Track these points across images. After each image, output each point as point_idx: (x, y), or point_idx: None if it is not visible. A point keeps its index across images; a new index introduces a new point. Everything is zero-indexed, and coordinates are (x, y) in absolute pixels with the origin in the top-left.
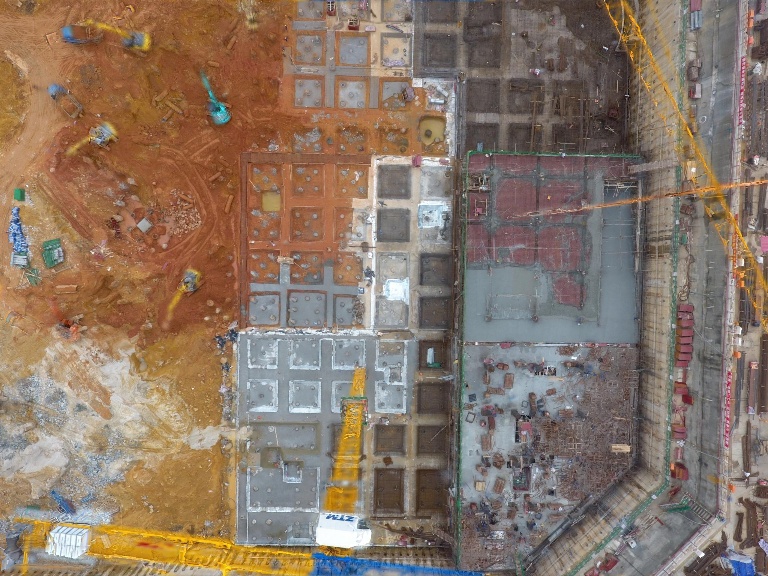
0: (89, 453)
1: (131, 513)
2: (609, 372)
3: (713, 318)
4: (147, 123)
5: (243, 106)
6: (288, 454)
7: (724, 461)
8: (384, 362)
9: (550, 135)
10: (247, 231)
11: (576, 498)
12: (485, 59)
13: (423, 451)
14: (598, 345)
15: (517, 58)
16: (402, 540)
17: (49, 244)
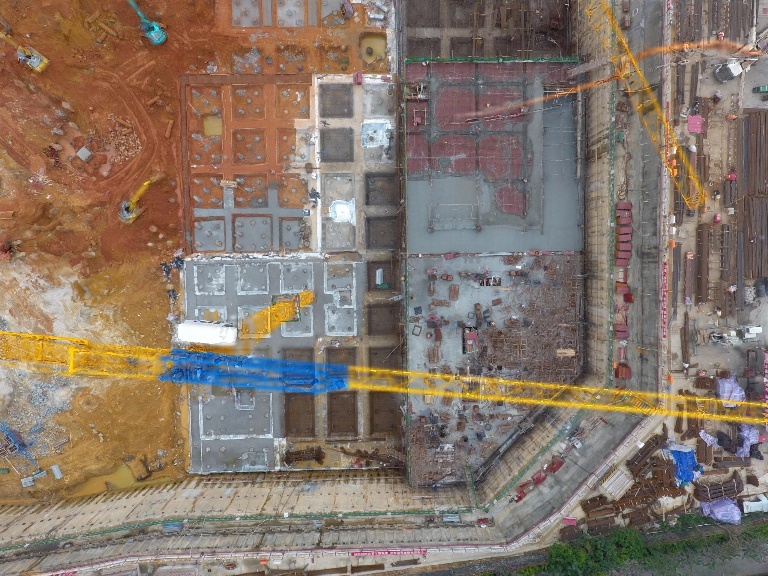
0: (34, 381)
1: (81, 443)
2: (554, 280)
3: (649, 211)
4: (81, 46)
5: (179, 27)
6: (239, 380)
7: (662, 352)
8: (333, 285)
9: (492, 49)
10: (188, 155)
11: (525, 408)
12: None
13: (376, 373)
14: (542, 253)
15: None
16: (357, 463)
17: None
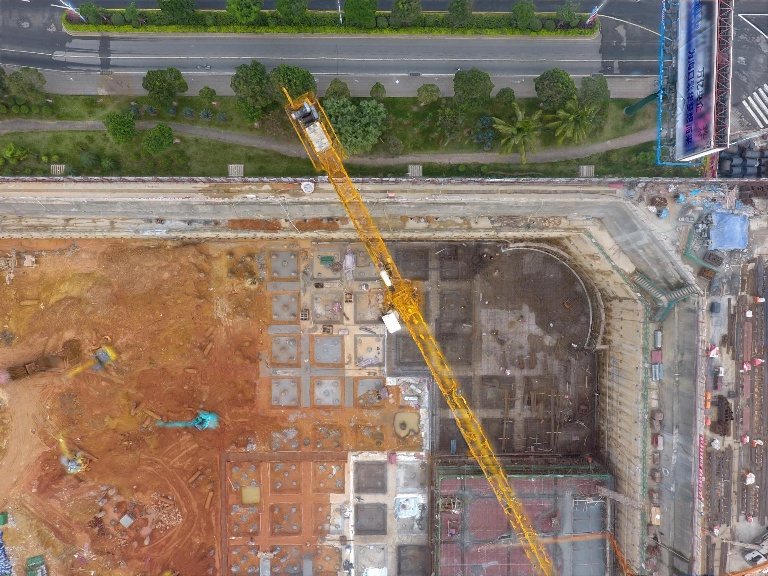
0: None
1: None
2: None
3: None
4: (127, 430)
5: (221, 410)
6: None
7: None
8: None
9: (522, 428)
10: (227, 527)
11: None
12: (457, 355)
13: None
14: None
15: (488, 356)
16: None
17: (32, 561)
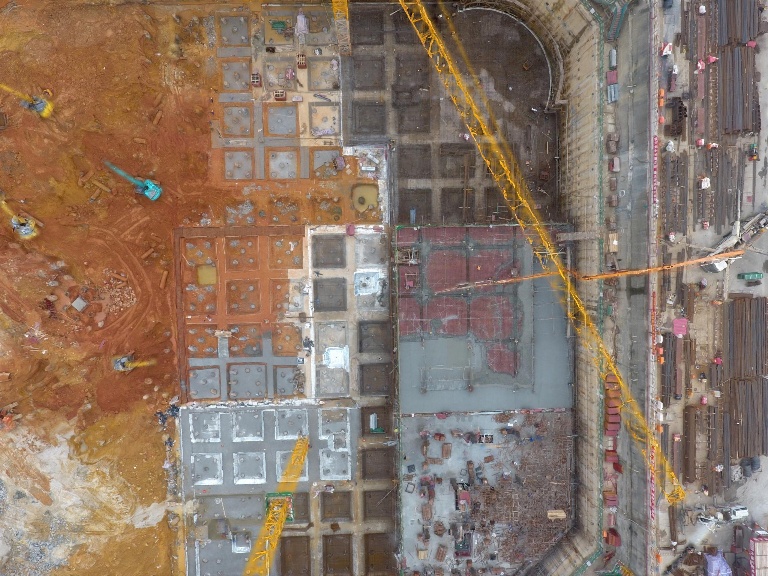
0: (31, 540)
1: None
2: (545, 437)
3: (637, 391)
4: (75, 203)
5: (172, 182)
6: (235, 525)
7: (651, 533)
8: (327, 430)
9: (483, 198)
10: (183, 306)
11: (518, 561)
12: (415, 124)
13: (370, 515)
14: (533, 411)
15: (446, 123)
16: None
17: None
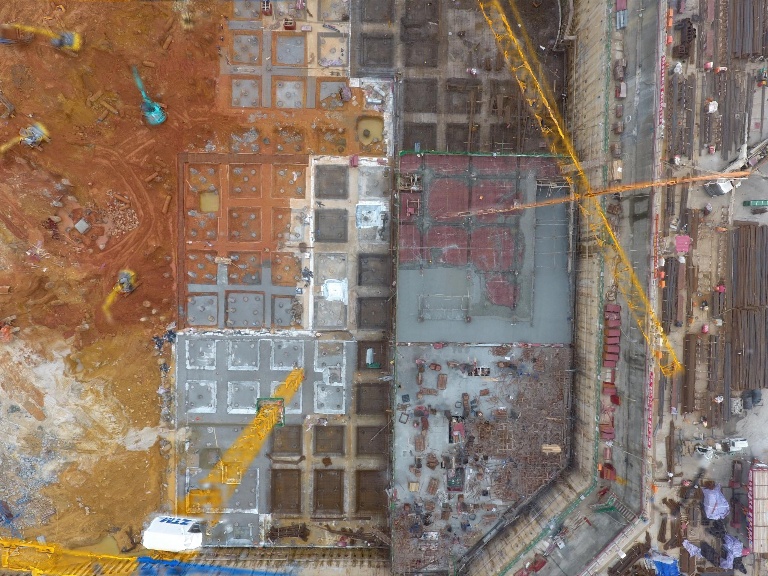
0: (22, 455)
1: (67, 515)
2: (542, 372)
3: None
4: (82, 123)
5: (179, 106)
6: (227, 455)
7: (647, 461)
8: (323, 363)
9: (488, 135)
10: (184, 232)
11: (510, 499)
12: (423, 59)
13: (363, 452)
14: (531, 345)
15: (454, 58)
16: (342, 541)
17: None
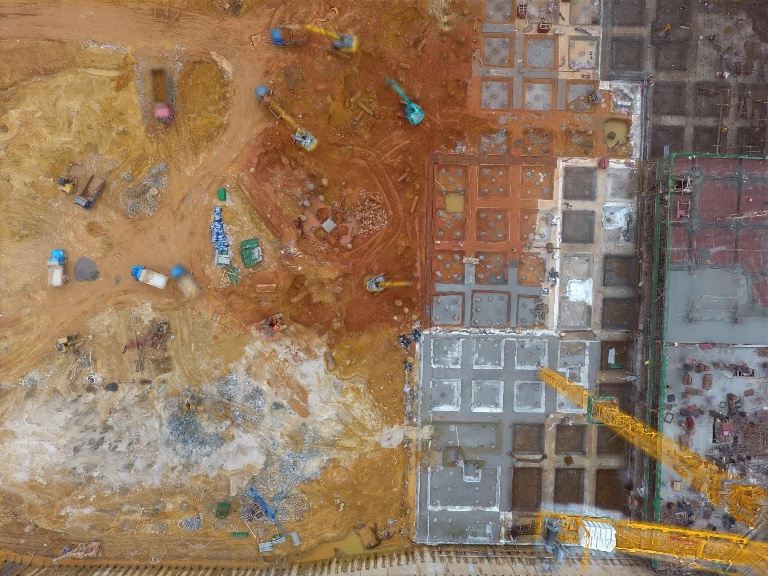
0: (286, 451)
1: (320, 511)
2: None
3: None
4: (338, 124)
5: (433, 108)
6: (470, 453)
7: None
8: (565, 362)
9: (735, 138)
10: (433, 231)
11: None
12: (670, 62)
13: (602, 451)
14: None
15: (704, 61)
16: None
17: (248, 243)
